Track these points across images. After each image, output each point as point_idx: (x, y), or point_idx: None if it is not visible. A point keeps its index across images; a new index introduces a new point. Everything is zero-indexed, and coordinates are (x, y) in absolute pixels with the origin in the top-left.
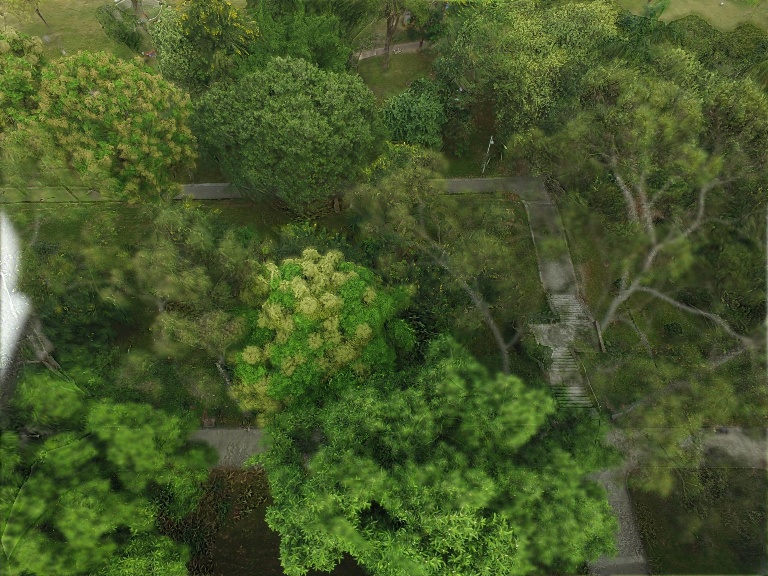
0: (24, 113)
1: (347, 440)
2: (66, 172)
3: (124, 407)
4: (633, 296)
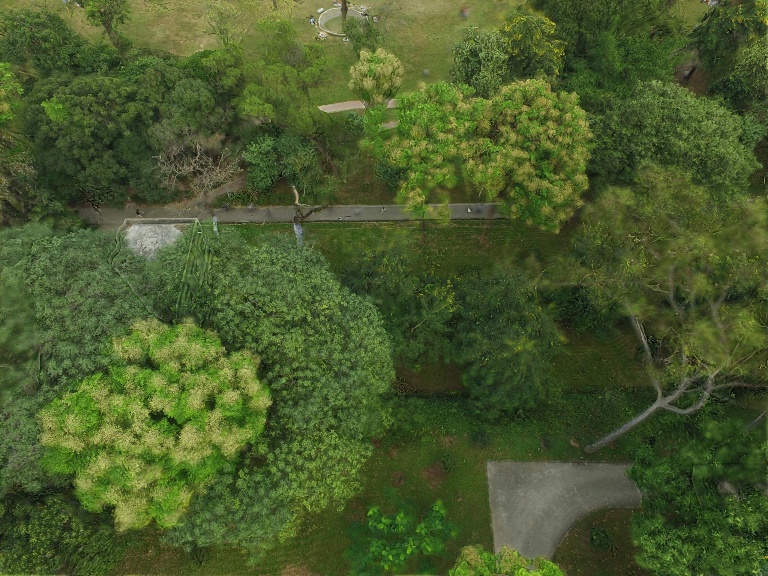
0: (473, 142)
1: None
2: (352, 190)
3: (582, 441)
4: None
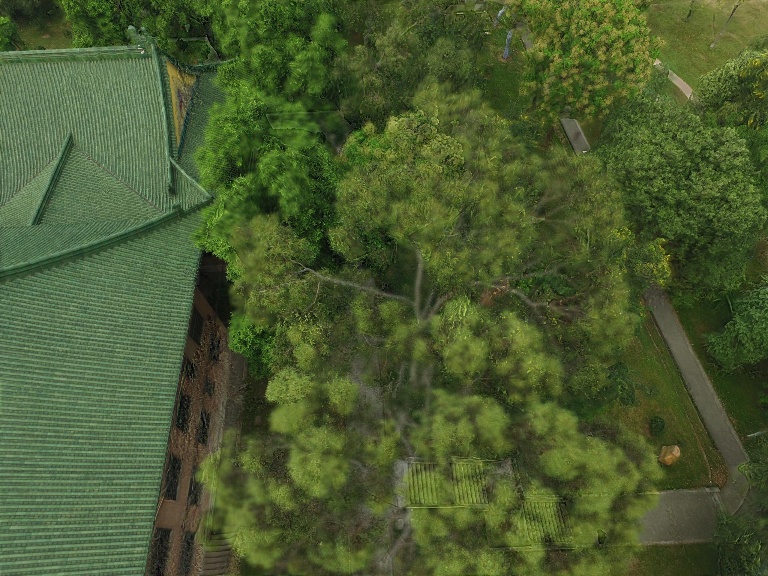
0: (563, 4)
1: (299, 154)
2: None
3: None
4: None
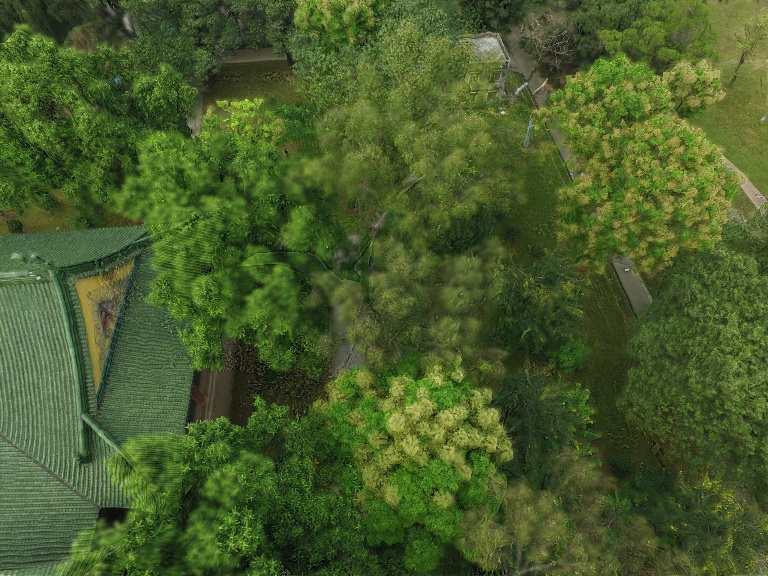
0: (609, 124)
1: (251, 486)
2: None
3: None
4: None
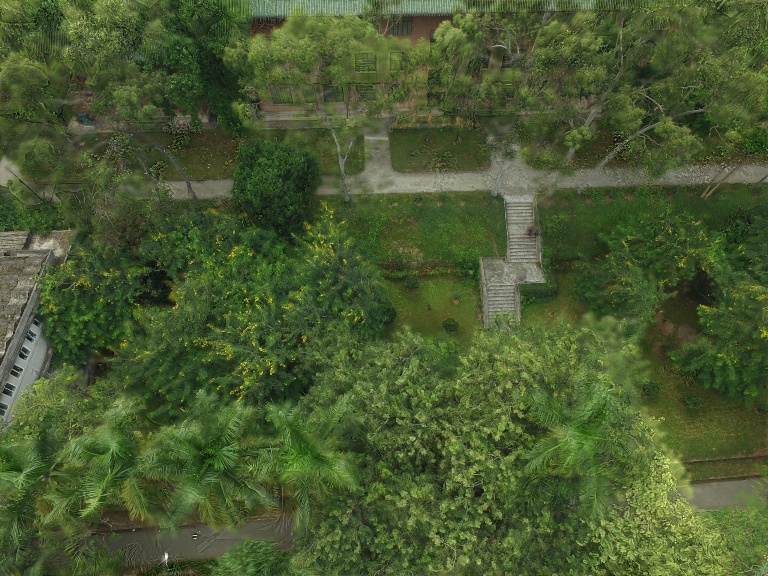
0: None
1: None
2: None
3: None
4: (433, 326)
